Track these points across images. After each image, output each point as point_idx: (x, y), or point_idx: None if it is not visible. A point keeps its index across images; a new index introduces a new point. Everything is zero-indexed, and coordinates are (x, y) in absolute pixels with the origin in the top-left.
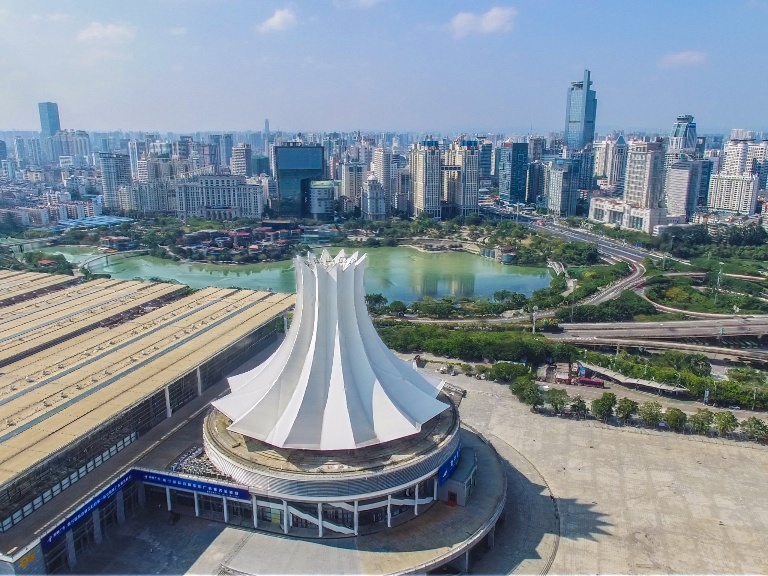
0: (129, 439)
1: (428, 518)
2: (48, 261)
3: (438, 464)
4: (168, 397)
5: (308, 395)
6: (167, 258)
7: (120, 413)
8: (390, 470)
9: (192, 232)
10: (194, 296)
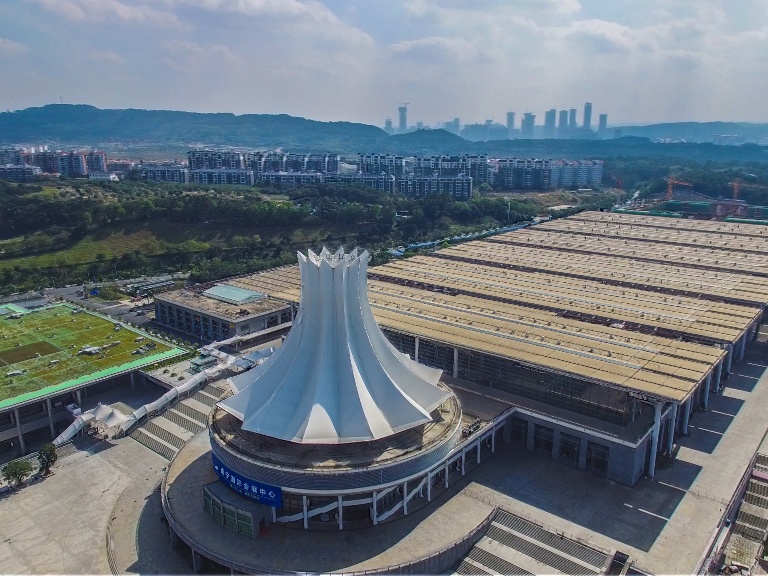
0: None
1: None
2: None
3: None
4: (418, 350)
5: None
6: None
7: None
8: None
9: None
10: (669, 341)
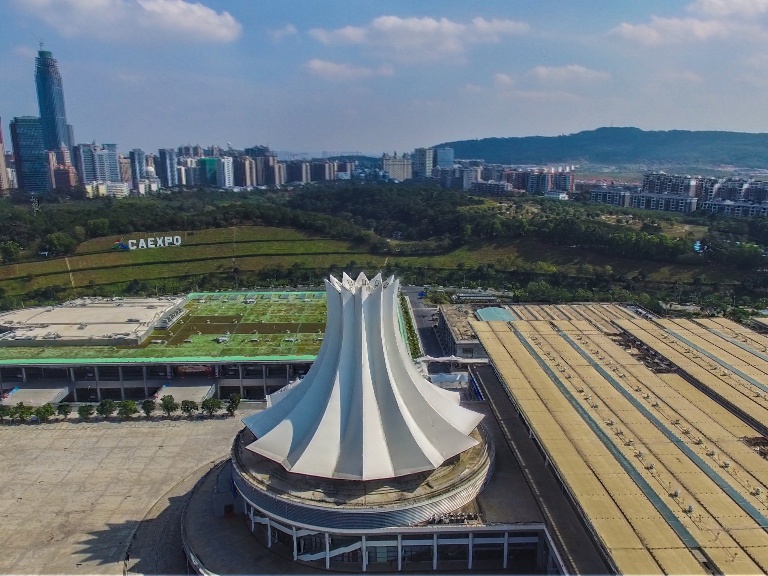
0: None
1: None
2: None
3: None
4: None
5: None
6: None
7: None
8: None
9: None
10: None
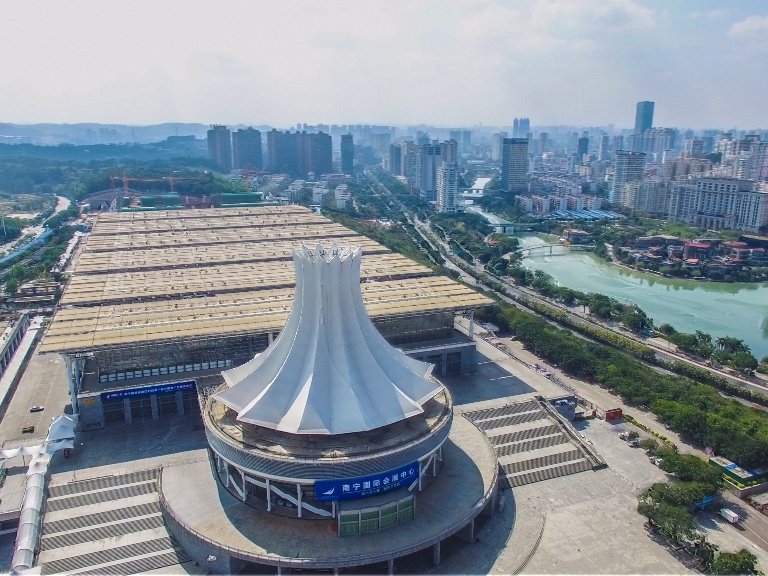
0: (224, 363)
1: (300, 524)
2: (494, 242)
3: (316, 476)
4: None
5: (263, 366)
6: (603, 257)
7: (190, 336)
8: (255, 453)
9: (649, 236)
10: (415, 280)
